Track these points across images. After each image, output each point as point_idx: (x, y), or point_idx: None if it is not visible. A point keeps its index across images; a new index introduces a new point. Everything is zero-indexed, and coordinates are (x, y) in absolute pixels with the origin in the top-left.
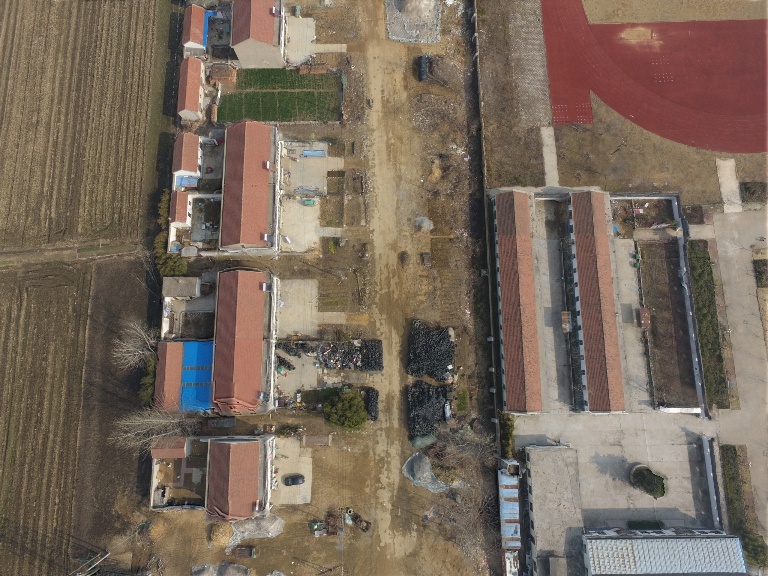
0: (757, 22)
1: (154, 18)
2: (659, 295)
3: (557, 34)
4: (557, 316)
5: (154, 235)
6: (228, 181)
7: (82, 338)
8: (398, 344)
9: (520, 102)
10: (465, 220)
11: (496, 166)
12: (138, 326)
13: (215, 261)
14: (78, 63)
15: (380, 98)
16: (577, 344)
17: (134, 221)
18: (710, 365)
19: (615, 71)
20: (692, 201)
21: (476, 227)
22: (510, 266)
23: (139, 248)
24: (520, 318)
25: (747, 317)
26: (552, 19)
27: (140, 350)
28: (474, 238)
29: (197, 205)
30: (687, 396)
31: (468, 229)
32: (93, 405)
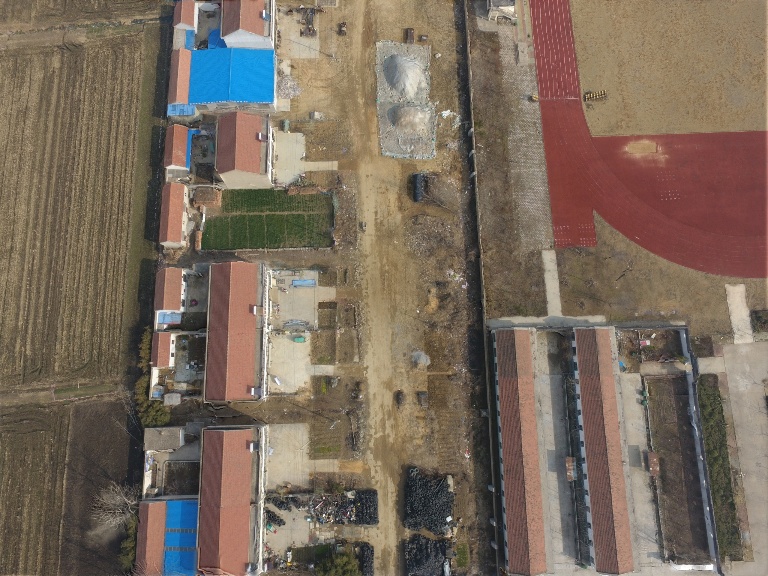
0: (766, 134)
1: (135, 132)
2: (668, 435)
3: (558, 148)
4: (561, 461)
5: (135, 378)
6: (212, 327)
7: (59, 489)
8: (394, 494)
9: (520, 223)
10: (464, 354)
11: (496, 294)
12: (118, 486)
13: (200, 408)
14: (54, 183)
15: (373, 220)
16: (582, 494)
17: (114, 358)
18: (722, 513)
19: (619, 188)
20: (701, 331)
21: (475, 361)
22: (511, 412)
23: (120, 388)
24: (523, 471)
25: (760, 459)
26: (553, 131)
27: (120, 508)
28: (473, 374)
29: (181, 342)
30: (698, 548)
31: (467, 364)
32: (71, 564)
